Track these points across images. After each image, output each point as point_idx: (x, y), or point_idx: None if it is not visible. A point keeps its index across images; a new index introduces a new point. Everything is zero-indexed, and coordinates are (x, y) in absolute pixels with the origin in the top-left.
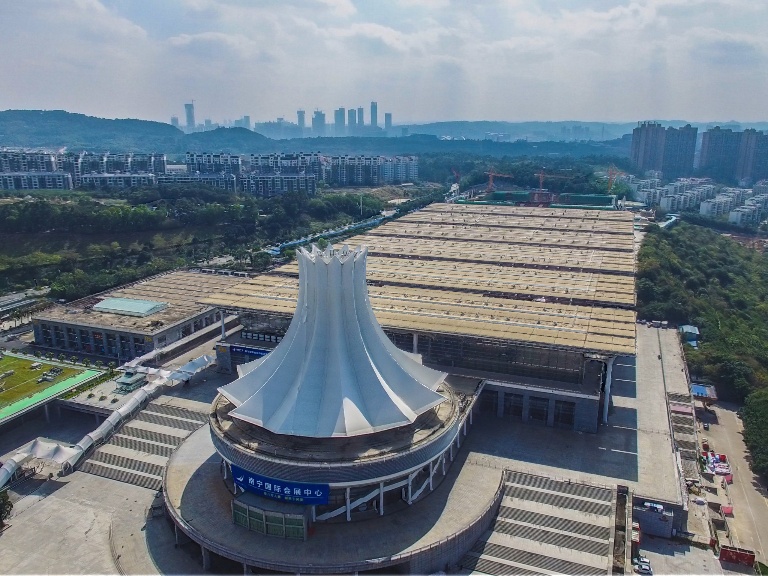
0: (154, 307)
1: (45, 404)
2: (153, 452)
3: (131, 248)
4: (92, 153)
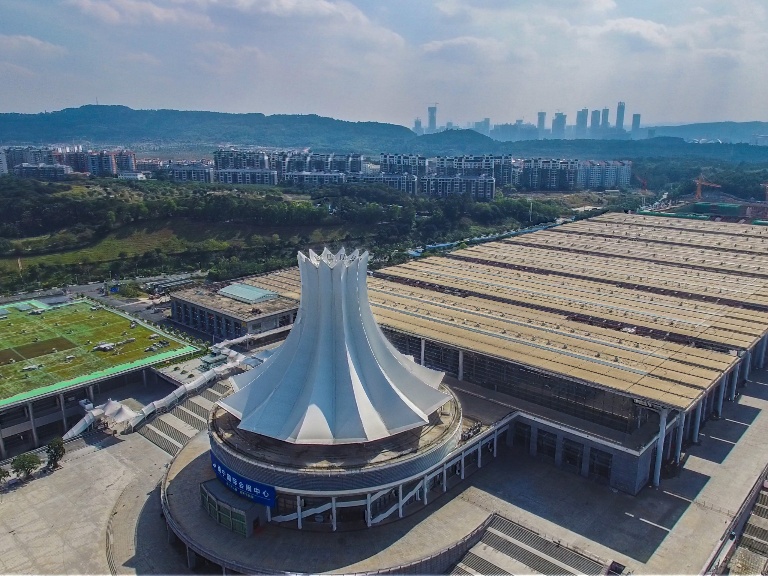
0: (264, 296)
1: (139, 370)
2: (197, 427)
3: (289, 241)
4: (301, 153)
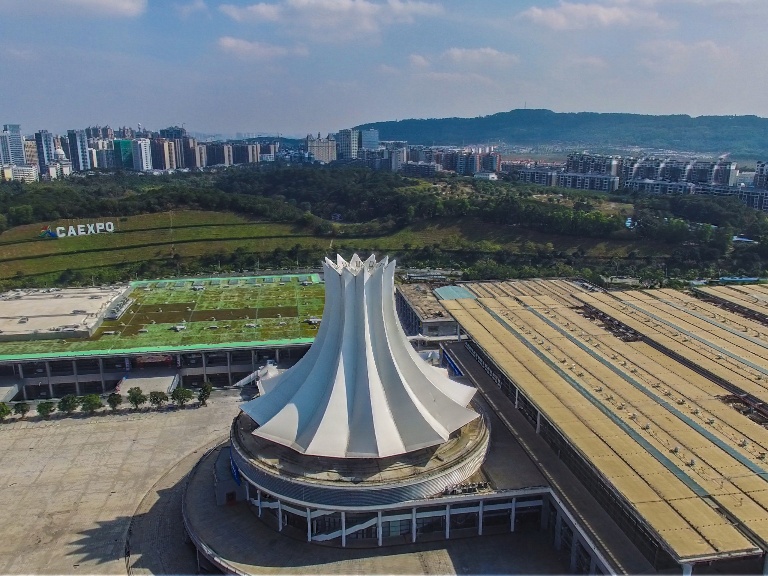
0: None
1: None
2: None
3: (562, 251)
4: (659, 159)
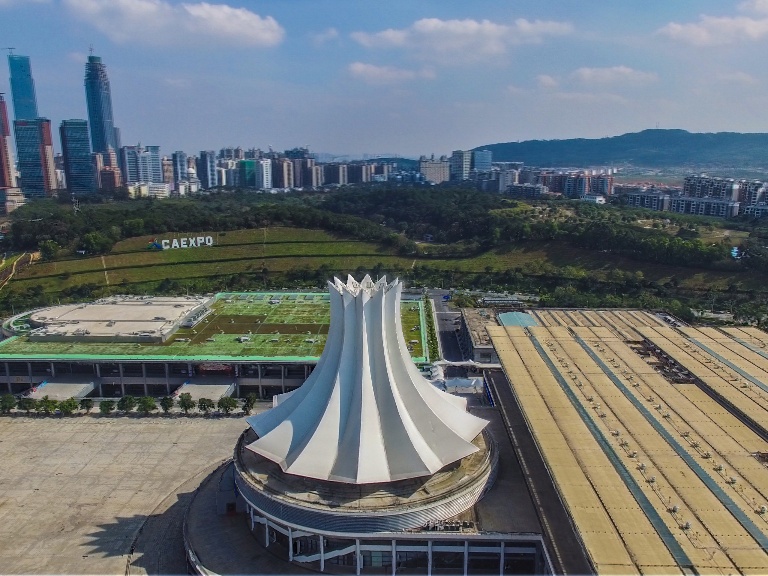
0: None
1: None
2: None
3: (653, 280)
4: None
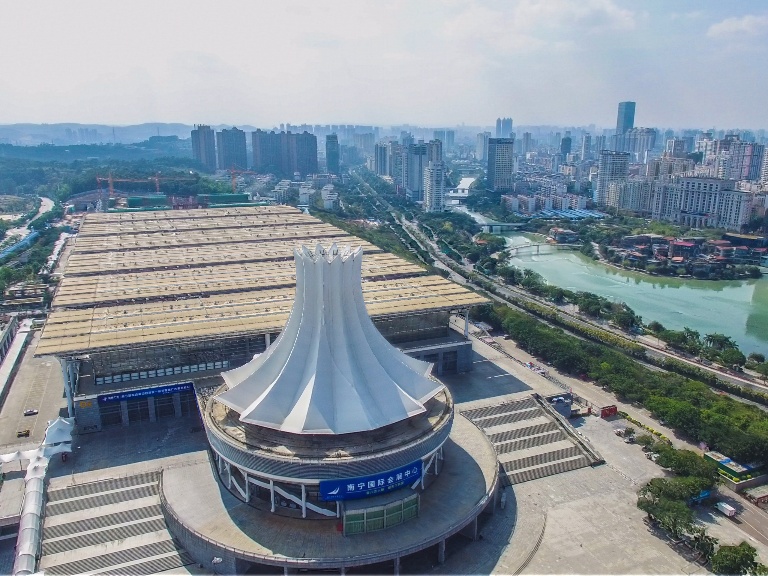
0: None
1: None
2: (124, 536)
3: None
4: None
